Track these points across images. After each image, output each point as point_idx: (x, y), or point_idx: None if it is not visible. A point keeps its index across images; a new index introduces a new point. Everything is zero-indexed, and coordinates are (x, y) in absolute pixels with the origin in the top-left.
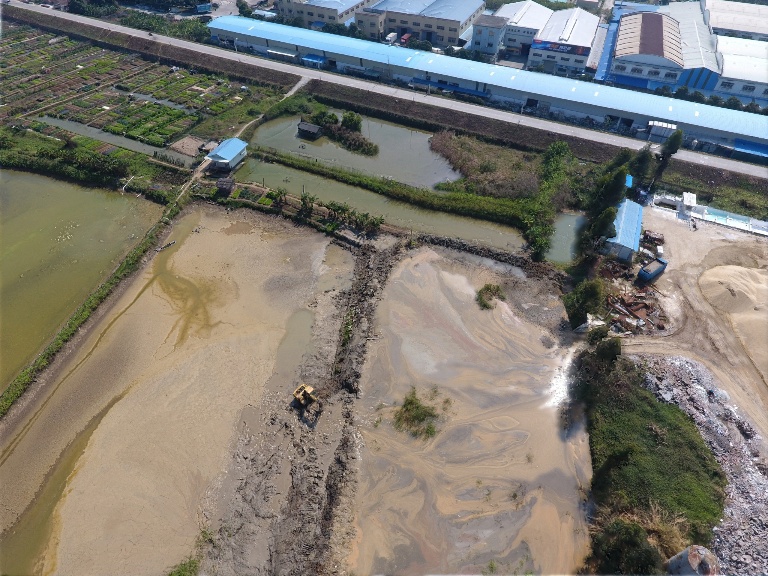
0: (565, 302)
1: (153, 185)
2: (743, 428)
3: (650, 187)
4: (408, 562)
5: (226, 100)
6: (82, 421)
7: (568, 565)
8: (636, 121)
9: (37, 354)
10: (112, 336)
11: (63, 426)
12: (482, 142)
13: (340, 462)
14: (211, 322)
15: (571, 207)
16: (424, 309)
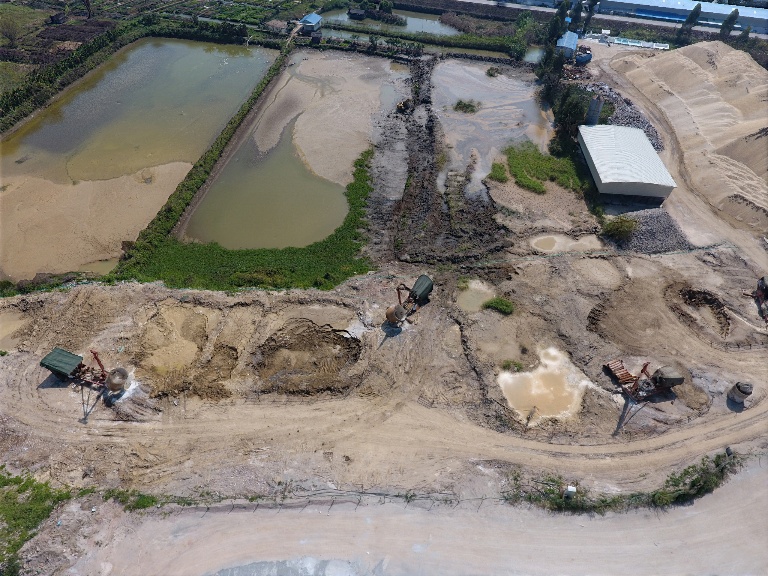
0: (536, 73)
1: (267, 39)
2: (626, 100)
3: (583, 31)
4: (473, 141)
5: (290, 2)
6: (287, 120)
7: (545, 139)
8: (574, 3)
9: (244, 102)
10: (282, 96)
11: (278, 121)
12: (475, 18)
13: (431, 121)
14: (336, 90)
15: (536, 43)
16: (458, 78)
